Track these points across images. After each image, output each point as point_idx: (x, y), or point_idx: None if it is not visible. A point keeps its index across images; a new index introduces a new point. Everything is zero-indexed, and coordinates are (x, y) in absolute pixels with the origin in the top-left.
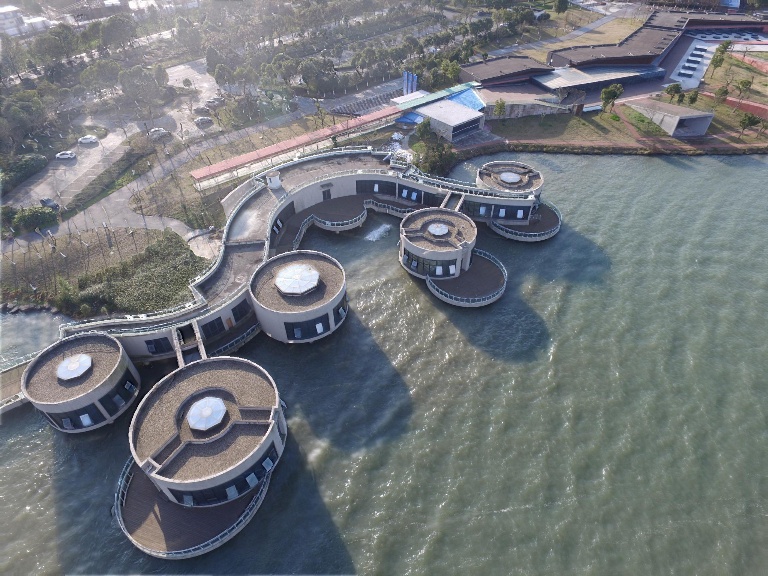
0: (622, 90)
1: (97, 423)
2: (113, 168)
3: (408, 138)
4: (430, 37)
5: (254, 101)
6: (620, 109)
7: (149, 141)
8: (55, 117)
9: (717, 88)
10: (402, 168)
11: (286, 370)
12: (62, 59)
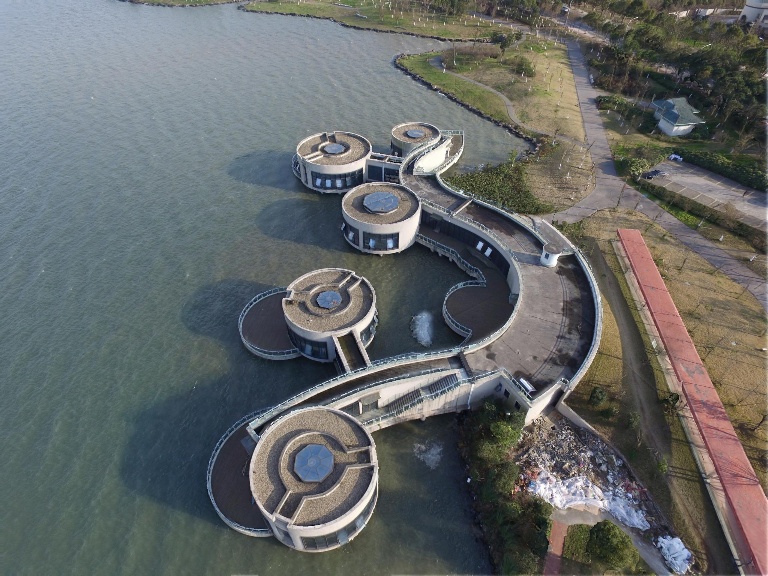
0: None
1: None
2: None
3: (660, 572)
4: None
5: None
6: None
7: None
8: None
9: None
10: None
11: None
12: None
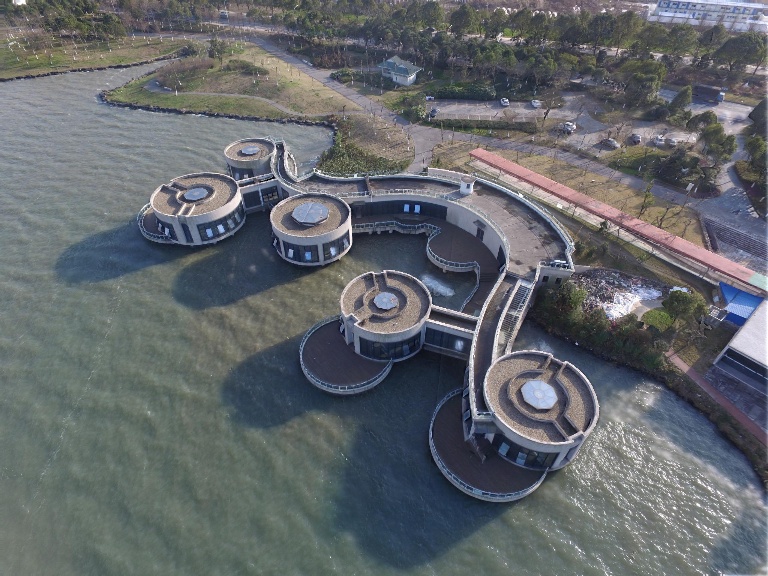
0: None
1: None
2: (492, 122)
3: None
4: None
5: (679, 161)
6: None
7: (549, 127)
8: (564, 82)
9: None
10: None
11: (253, 241)
12: (652, 50)
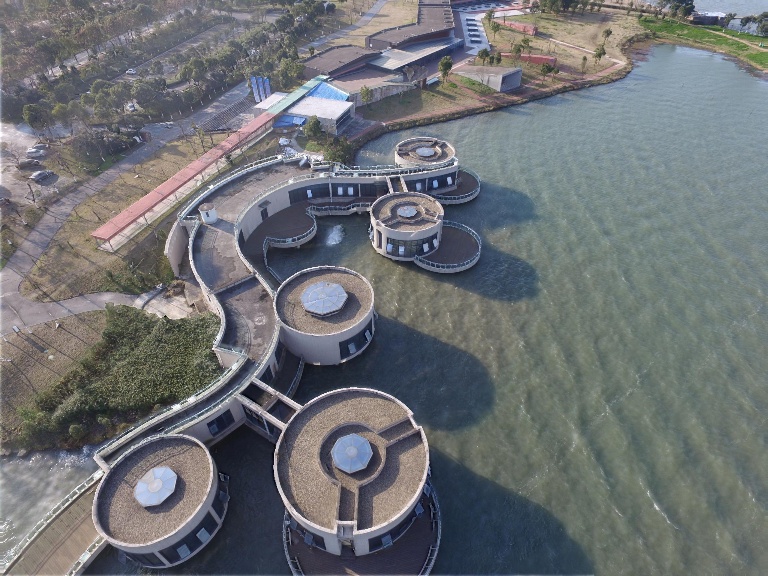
0: (452, 61)
1: (210, 534)
2: None
3: (295, 141)
4: (249, 39)
5: (94, 139)
6: (452, 77)
7: None
8: None
9: (503, 48)
10: (325, 168)
11: None
12: None
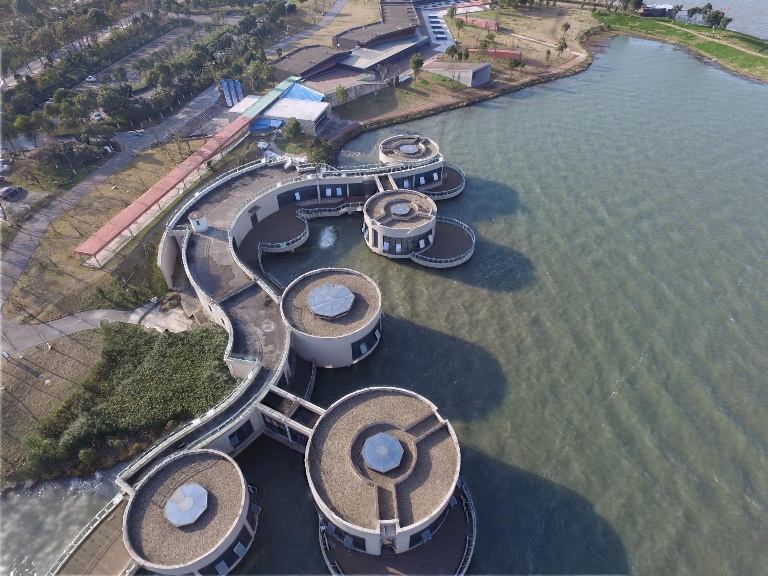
0: (422, 58)
1: None
2: None
3: (274, 144)
4: (214, 42)
5: (62, 151)
6: (422, 75)
7: None
8: None
9: (469, 44)
10: (311, 170)
11: None
12: None
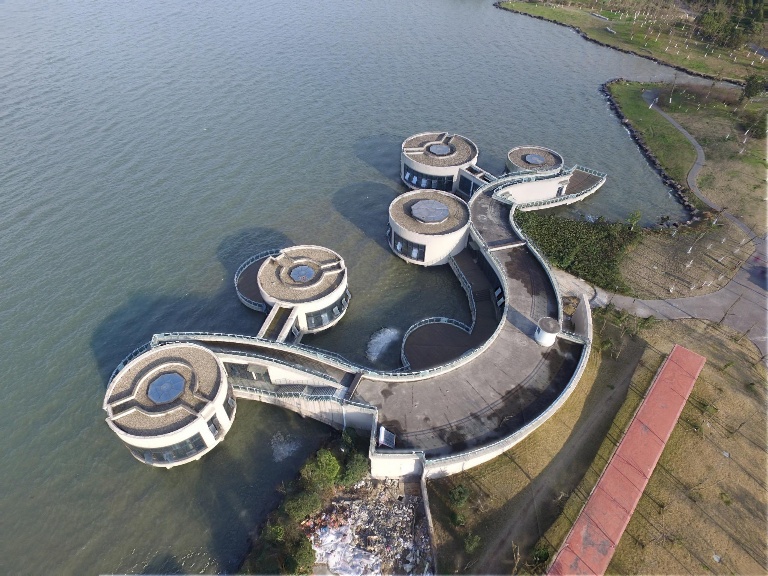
0: None
1: None
2: None
3: None
4: None
5: None
6: None
7: None
8: None
9: None
10: None
11: None
12: None
